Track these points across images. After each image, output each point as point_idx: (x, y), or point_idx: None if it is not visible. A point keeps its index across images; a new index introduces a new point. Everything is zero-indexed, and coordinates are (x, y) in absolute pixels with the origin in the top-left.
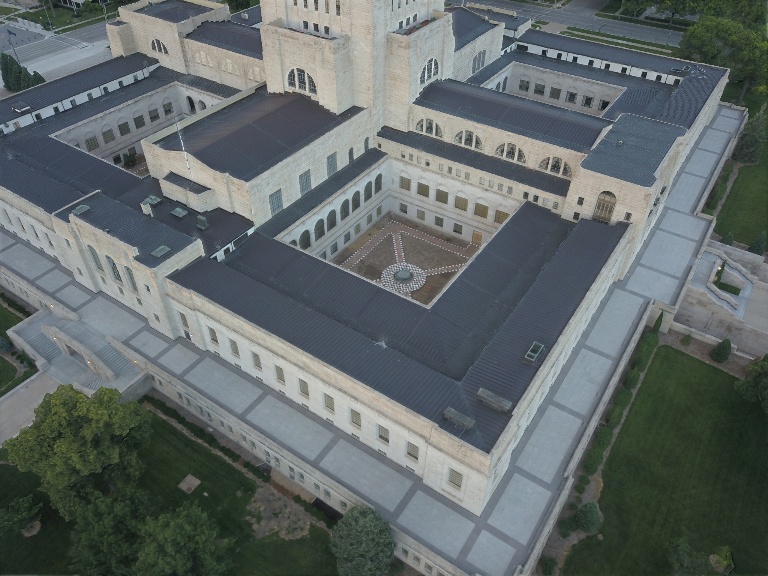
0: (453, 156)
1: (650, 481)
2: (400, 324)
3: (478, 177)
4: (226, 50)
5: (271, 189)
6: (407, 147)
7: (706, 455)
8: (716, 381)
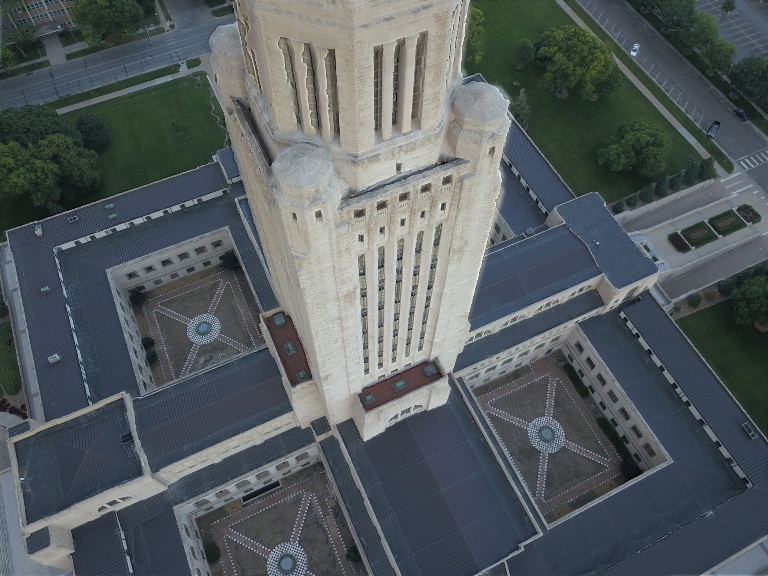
0: (513, 339)
1: (764, 407)
2: (677, 487)
3: (541, 337)
4: (229, 440)
5: None
6: (480, 363)
7: (755, 366)
8: (709, 319)
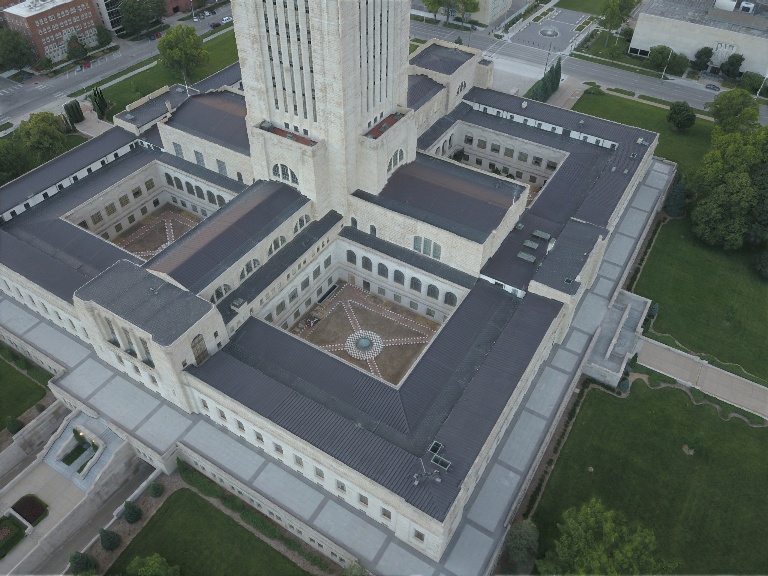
0: None
1: None
2: None
3: None
4: None
5: (173, 139)
6: None
7: None
8: None
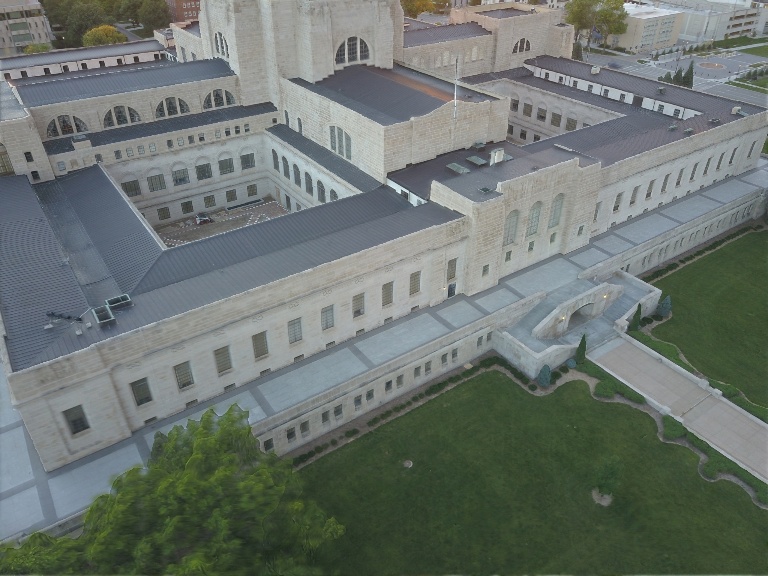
0: None
1: None
2: None
3: None
4: None
5: None
6: None
7: None
8: None
